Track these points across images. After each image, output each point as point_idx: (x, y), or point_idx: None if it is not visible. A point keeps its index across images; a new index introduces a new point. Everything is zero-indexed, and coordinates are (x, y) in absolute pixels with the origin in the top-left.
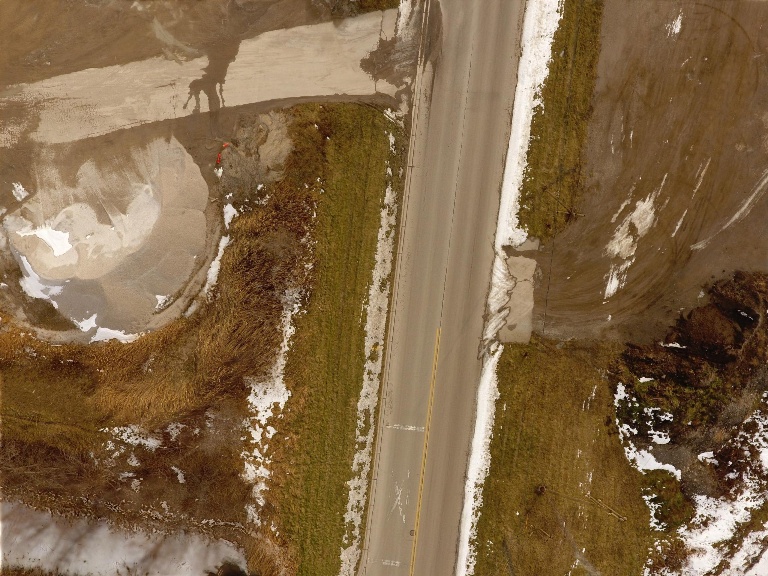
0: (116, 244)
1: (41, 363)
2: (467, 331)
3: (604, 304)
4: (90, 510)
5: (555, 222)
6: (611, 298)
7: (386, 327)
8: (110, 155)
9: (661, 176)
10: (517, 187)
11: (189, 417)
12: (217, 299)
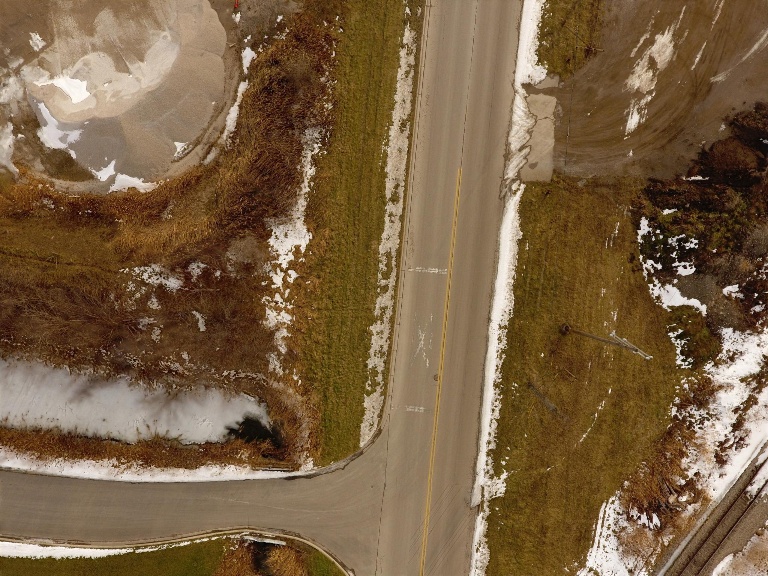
0: (135, 87)
1: (59, 214)
2: (488, 171)
3: (625, 140)
4: (109, 367)
5: (574, 58)
6: (632, 133)
7: (407, 168)
8: (127, 2)
9: (679, 9)
10: (536, 23)
11: (210, 255)
12: (236, 145)
